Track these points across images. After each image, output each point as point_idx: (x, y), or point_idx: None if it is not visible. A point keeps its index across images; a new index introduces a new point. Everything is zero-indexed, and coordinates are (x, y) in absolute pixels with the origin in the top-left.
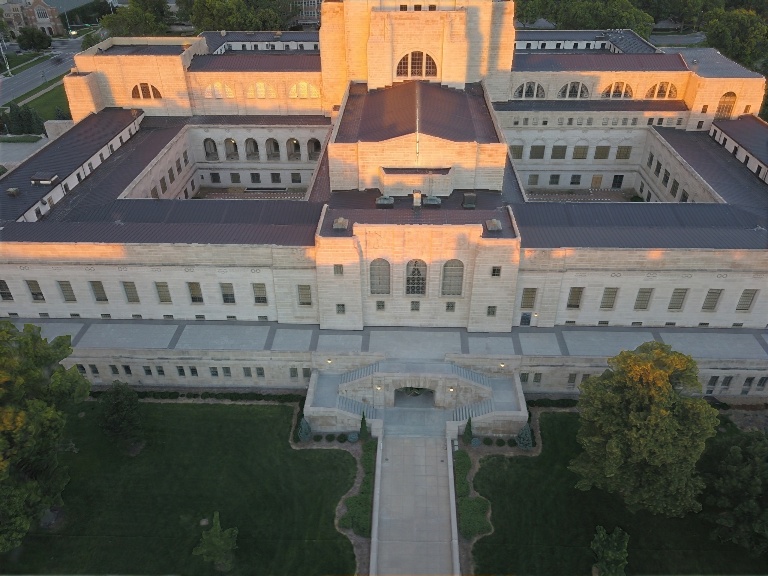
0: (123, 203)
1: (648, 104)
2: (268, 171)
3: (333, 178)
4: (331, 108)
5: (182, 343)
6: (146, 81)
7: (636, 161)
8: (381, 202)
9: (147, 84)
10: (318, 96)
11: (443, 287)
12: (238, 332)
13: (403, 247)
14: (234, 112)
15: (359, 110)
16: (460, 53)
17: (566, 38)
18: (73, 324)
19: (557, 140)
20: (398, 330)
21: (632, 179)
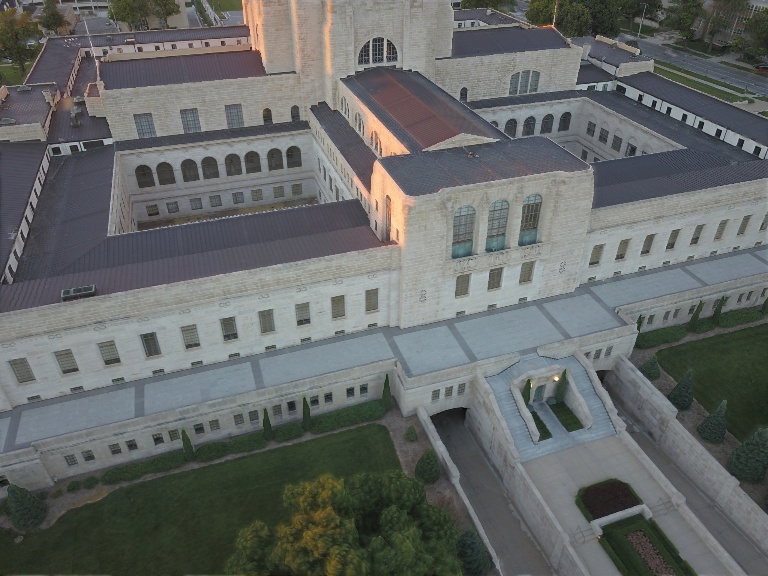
0: None
1: None
2: None
3: None
4: None
5: None
6: None
7: None
8: None
9: None
10: None
11: None
12: None
13: None
14: None
15: None
16: None
17: (737, 127)
18: None
19: None
20: None
21: None
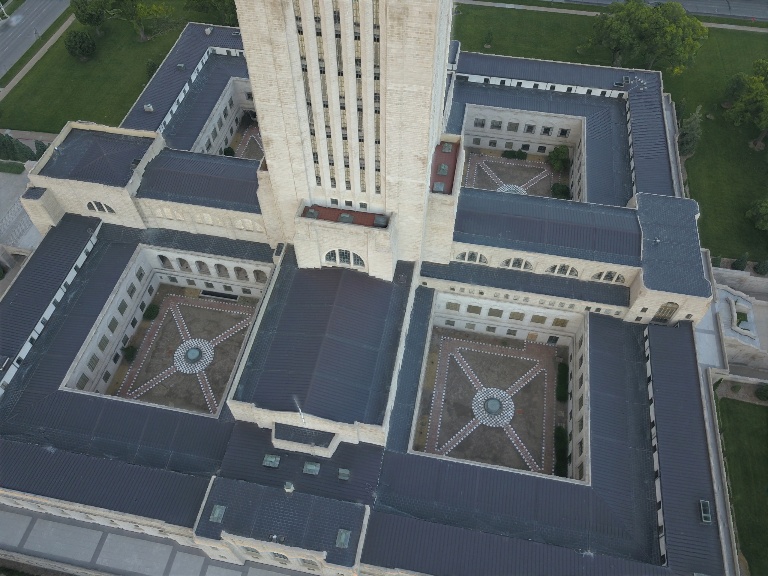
0: (63, 397)
1: (592, 287)
2: (220, 283)
3: (236, 415)
4: (276, 244)
5: (102, 558)
6: (98, 201)
7: (572, 330)
8: (267, 464)
9: (100, 202)
10: (263, 230)
11: (304, 561)
12: (147, 550)
13: (264, 548)
14: (186, 229)
15: (280, 308)
16: (385, 259)
17: (580, 82)
18: (24, 517)
19: (494, 306)
20: (272, 570)
21: (567, 341)
